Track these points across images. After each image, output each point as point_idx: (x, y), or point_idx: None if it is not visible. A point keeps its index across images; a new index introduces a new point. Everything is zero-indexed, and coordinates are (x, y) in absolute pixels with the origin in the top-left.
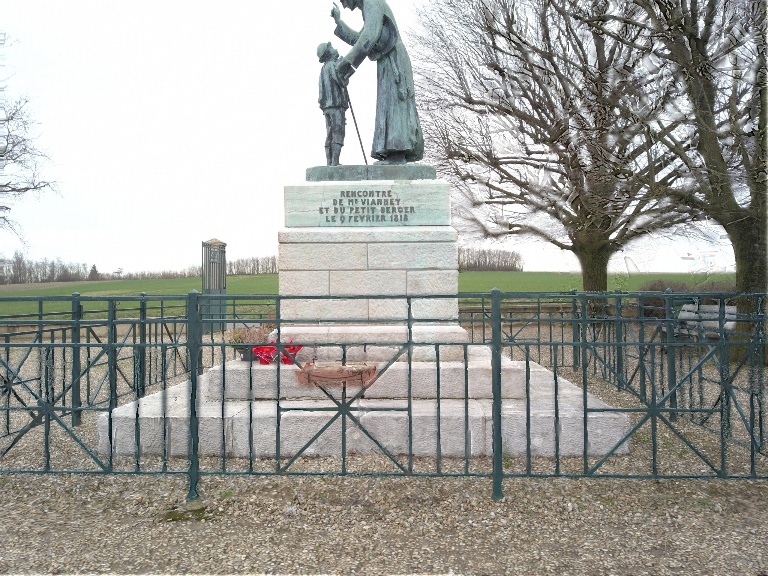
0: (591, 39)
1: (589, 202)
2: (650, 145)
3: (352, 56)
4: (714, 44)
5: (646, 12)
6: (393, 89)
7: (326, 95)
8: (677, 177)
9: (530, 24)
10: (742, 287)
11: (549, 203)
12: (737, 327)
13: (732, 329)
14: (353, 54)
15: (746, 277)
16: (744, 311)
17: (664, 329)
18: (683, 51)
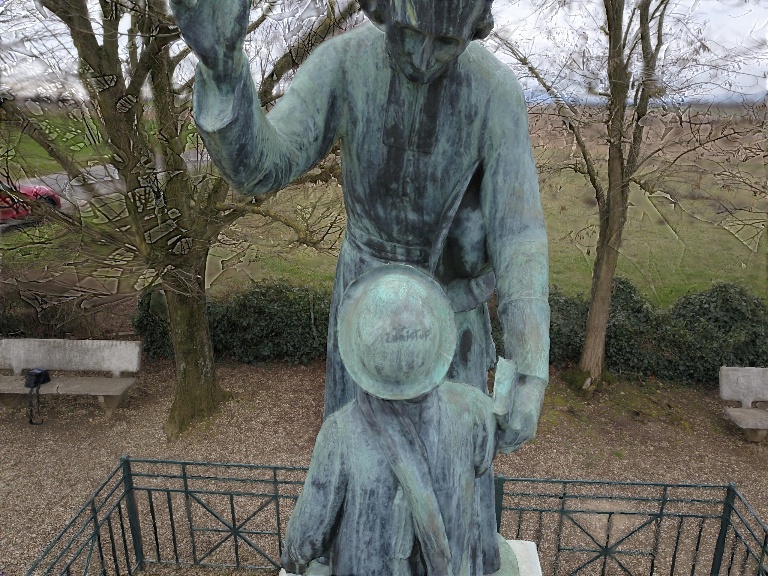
0: None
1: None
2: (134, 187)
3: None
4: (179, 39)
5: None
6: None
7: None
8: (182, 237)
9: None
10: (187, 335)
11: None
12: (186, 380)
13: (137, 371)
14: None
15: (189, 323)
16: (192, 361)
17: (17, 391)
18: (84, 9)
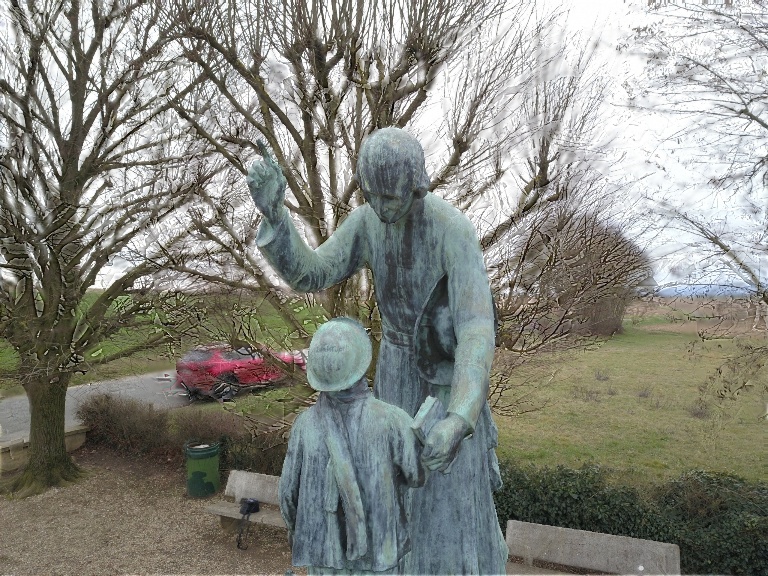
0: (66, 89)
1: (194, 382)
2: None
3: (478, 408)
4: None
5: (271, 145)
6: (488, 468)
7: (372, 525)
8: None
9: (10, 48)
10: None
11: (8, 322)
12: None
13: None
14: (480, 401)
15: None
16: None
17: (233, 515)
18: (321, 213)
